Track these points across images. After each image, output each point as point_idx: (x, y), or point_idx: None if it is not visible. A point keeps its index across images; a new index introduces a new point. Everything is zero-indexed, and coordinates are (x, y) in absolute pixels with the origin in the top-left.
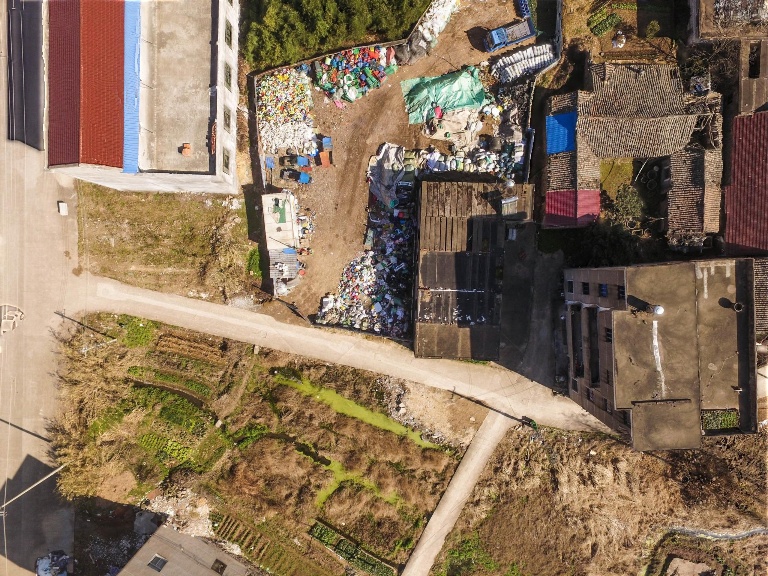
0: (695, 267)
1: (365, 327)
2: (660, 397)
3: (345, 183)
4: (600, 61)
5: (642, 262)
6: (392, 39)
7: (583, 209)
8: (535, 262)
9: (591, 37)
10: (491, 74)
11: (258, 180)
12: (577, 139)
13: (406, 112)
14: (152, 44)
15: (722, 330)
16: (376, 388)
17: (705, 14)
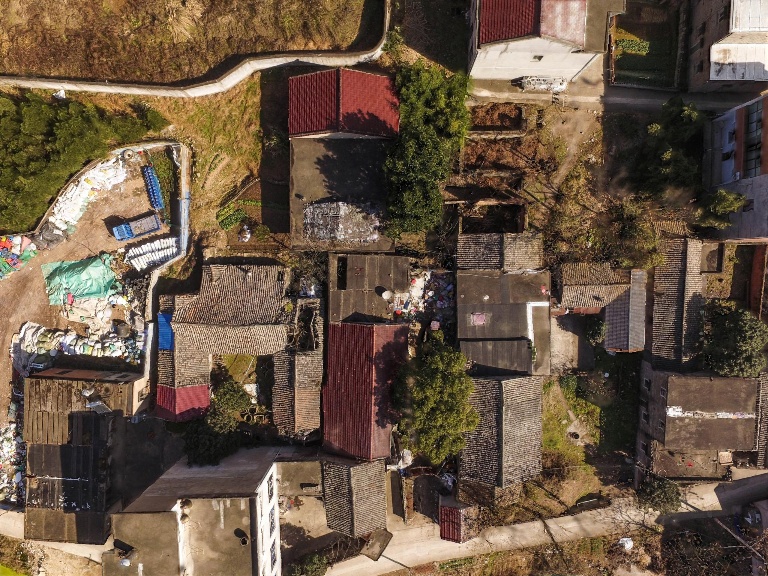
0: (176, 516)
1: (0, 498)
2: None
3: None
4: (226, 254)
5: (265, 445)
6: (19, 232)
7: (185, 405)
8: (164, 441)
9: (217, 231)
10: (124, 262)
11: None
12: (175, 341)
13: (47, 293)
14: None
15: (238, 558)
16: (21, 551)
17: (295, 228)
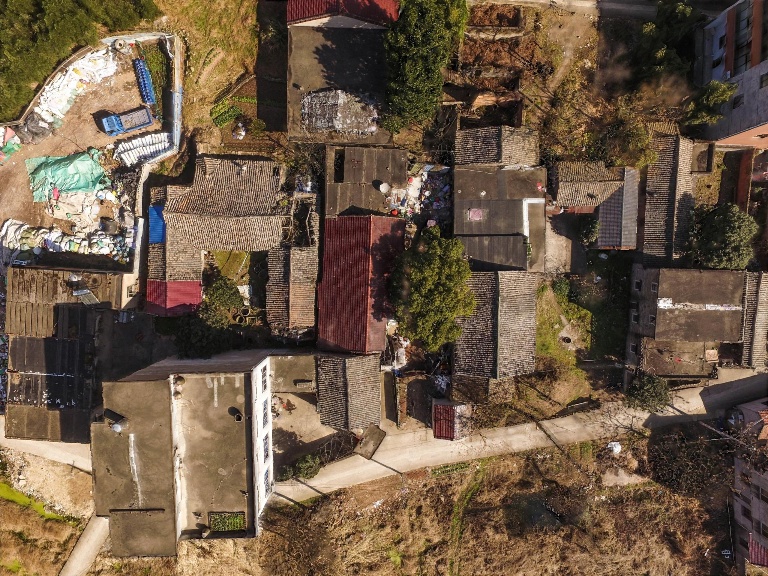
0: (169, 385)
1: None
2: (137, 506)
3: None
4: (220, 151)
5: (257, 348)
6: (2, 120)
7: (176, 300)
8: (153, 343)
9: (211, 128)
10: (113, 158)
11: None
12: (167, 232)
13: (31, 190)
14: None
15: (231, 437)
16: None
17: (292, 119)
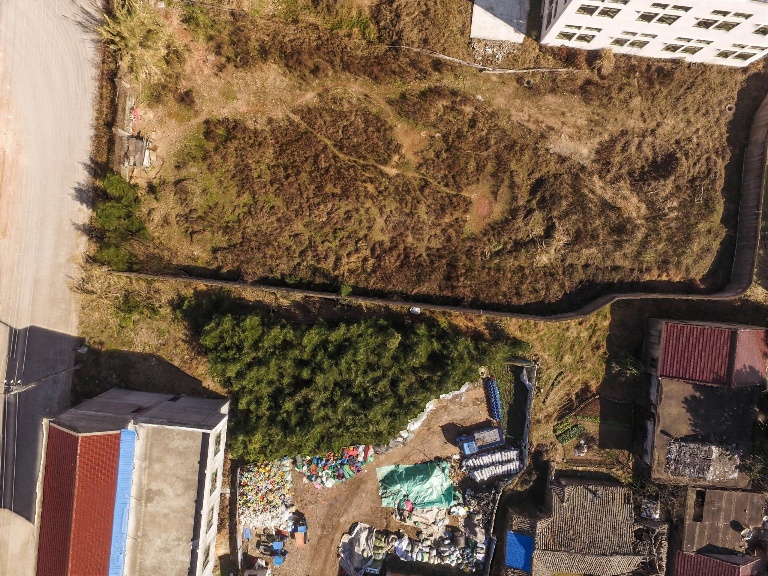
0: None
1: None
2: None
3: (317, 556)
4: (562, 467)
5: None
6: None
7: None
8: None
9: (556, 445)
10: (461, 471)
11: (235, 550)
12: (533, 565)
13: (379, 496)
14: (140, 501)
15: None
16: None
17: (657, 462)
